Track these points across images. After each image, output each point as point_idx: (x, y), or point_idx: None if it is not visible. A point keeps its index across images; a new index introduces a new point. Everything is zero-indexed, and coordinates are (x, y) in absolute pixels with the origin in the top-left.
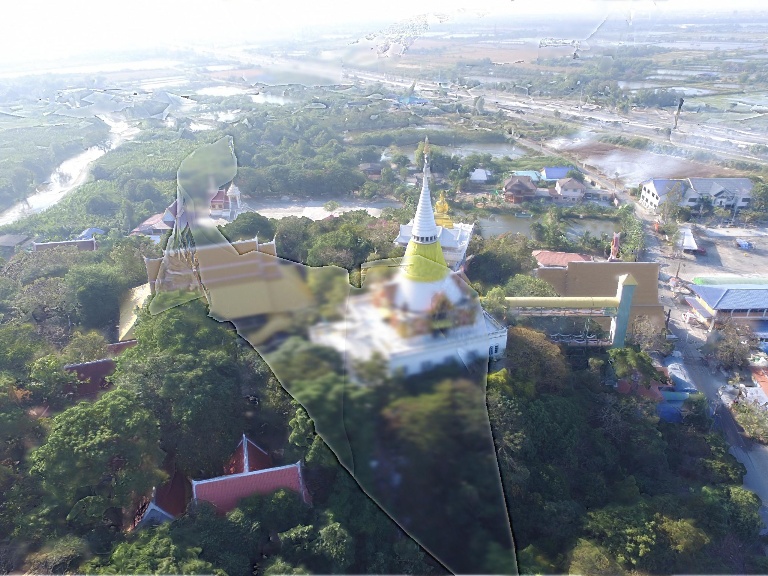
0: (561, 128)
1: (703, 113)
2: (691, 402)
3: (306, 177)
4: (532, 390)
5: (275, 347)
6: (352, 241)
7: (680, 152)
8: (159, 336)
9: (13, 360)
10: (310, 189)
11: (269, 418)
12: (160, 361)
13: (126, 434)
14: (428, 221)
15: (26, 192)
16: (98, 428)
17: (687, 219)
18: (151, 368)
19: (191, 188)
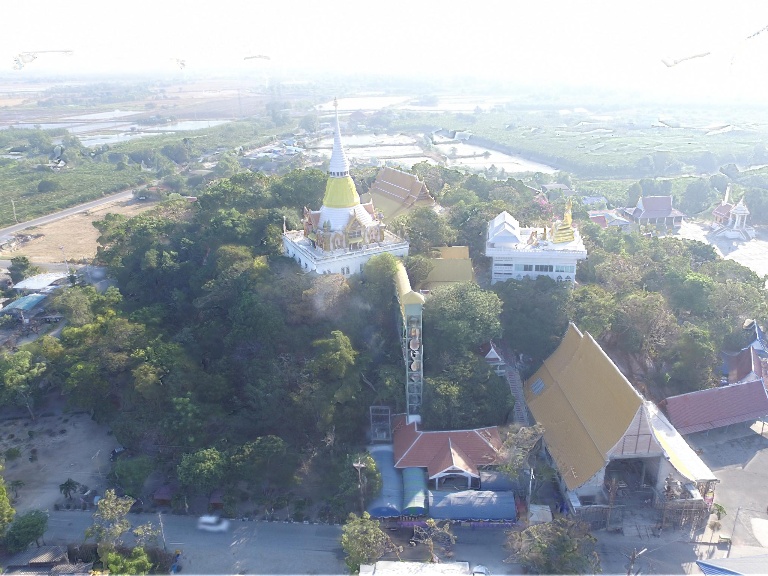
0: None
1: None
2: None
3: None
4: (263, 289)
5: None
6: (470, 207)
7: None
8: None
9: None
10: None
11: None
12: None
13: None
14: None
15: (668, 173)
16: None
17: None
18: None
19: (107, 65)
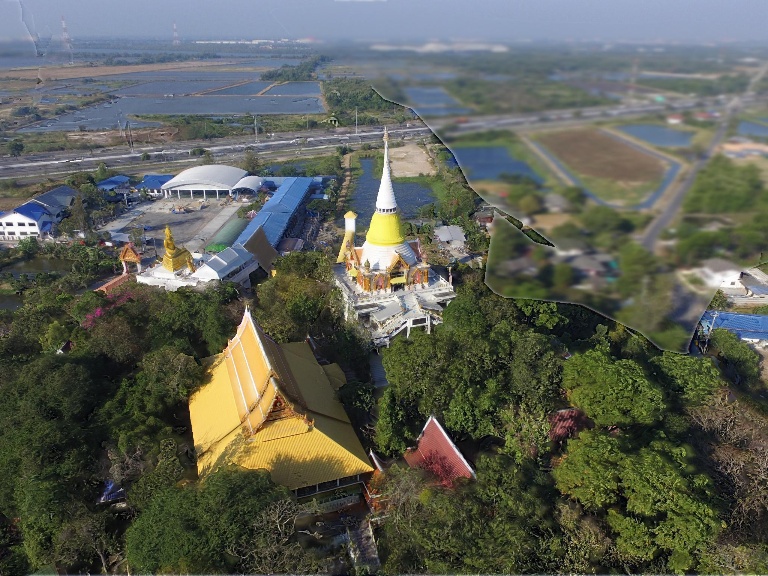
0: None
1: None
2: None
3: None
4: None
5: None
6: (219, 293)
7: None
8: None
9: None
10: None
11: None
12: None
13: None
14: None
15: None
16: (619, 364)
17: None
18: None
19: None
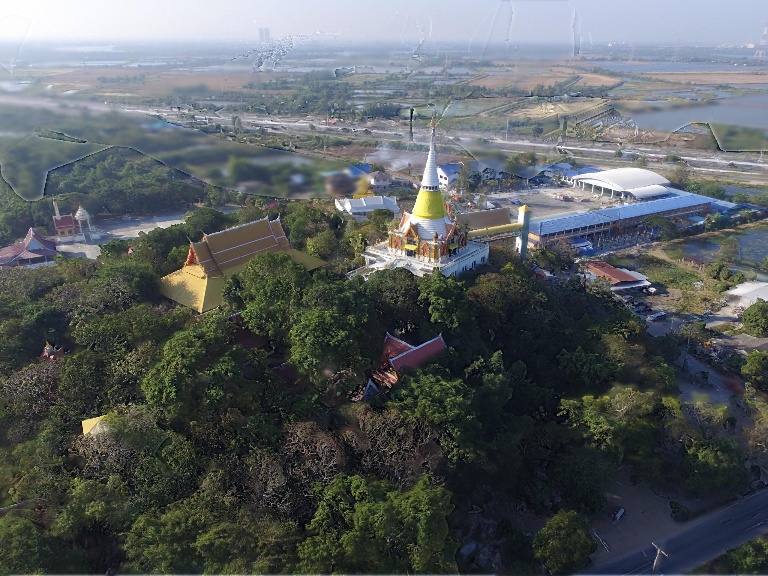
0: (326, 138)
1: (419, 120)
2: (573, 281)
3: (146, 195)
4: None
5: (762, 114)
6: (322, 215)
7: (428, 148)
8: (295, 279)
9: (170, 325)
10: (152, 206)
11: (403, 316)
12: (322, 289)
13: (351, 331)
14: (436, 175)
15: None
16: (332, 330)
17: (473, 190)
18: (318, 295)
19: None
